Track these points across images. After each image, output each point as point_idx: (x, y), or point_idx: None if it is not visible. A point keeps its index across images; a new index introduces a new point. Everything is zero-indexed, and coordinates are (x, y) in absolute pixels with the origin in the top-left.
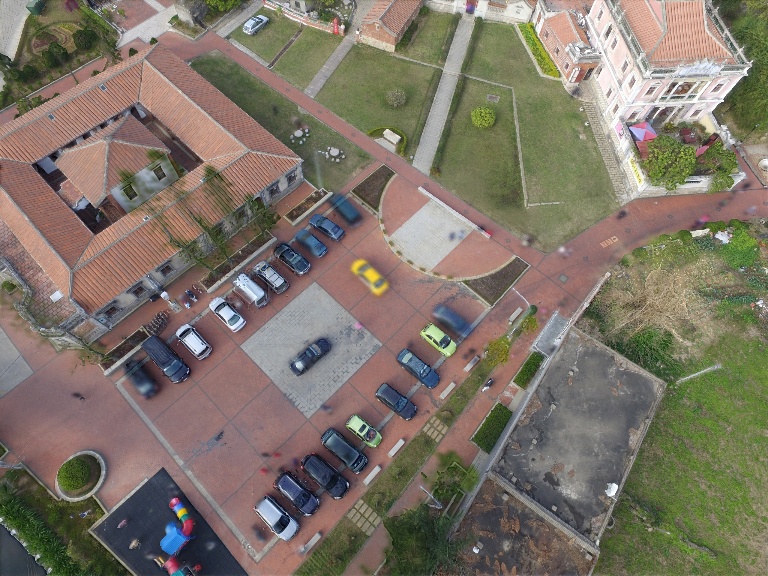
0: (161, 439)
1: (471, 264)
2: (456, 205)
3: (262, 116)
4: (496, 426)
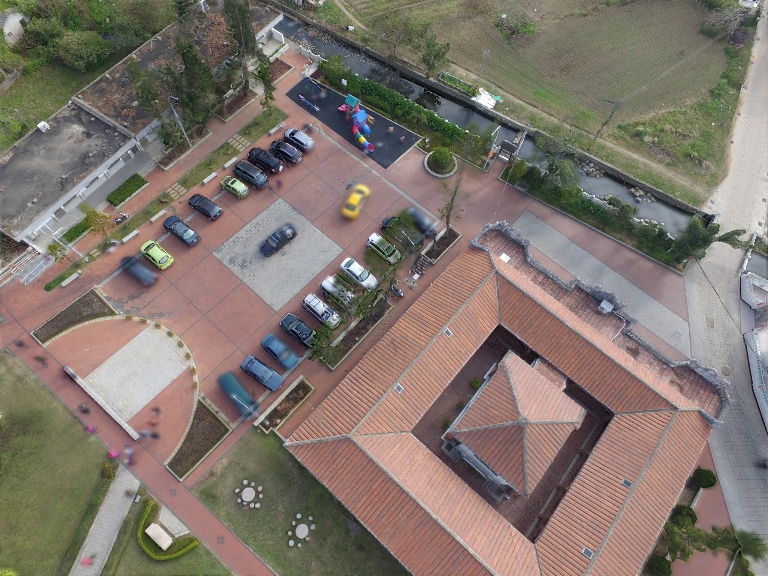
0: (392, 185)
1: (100, 335)
2: (95, 416)
3: (363, 575)
4: (124, 188)
